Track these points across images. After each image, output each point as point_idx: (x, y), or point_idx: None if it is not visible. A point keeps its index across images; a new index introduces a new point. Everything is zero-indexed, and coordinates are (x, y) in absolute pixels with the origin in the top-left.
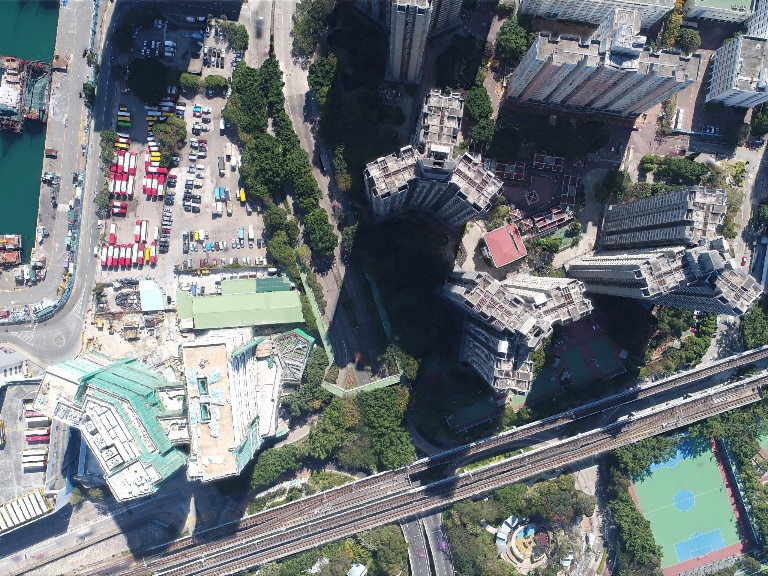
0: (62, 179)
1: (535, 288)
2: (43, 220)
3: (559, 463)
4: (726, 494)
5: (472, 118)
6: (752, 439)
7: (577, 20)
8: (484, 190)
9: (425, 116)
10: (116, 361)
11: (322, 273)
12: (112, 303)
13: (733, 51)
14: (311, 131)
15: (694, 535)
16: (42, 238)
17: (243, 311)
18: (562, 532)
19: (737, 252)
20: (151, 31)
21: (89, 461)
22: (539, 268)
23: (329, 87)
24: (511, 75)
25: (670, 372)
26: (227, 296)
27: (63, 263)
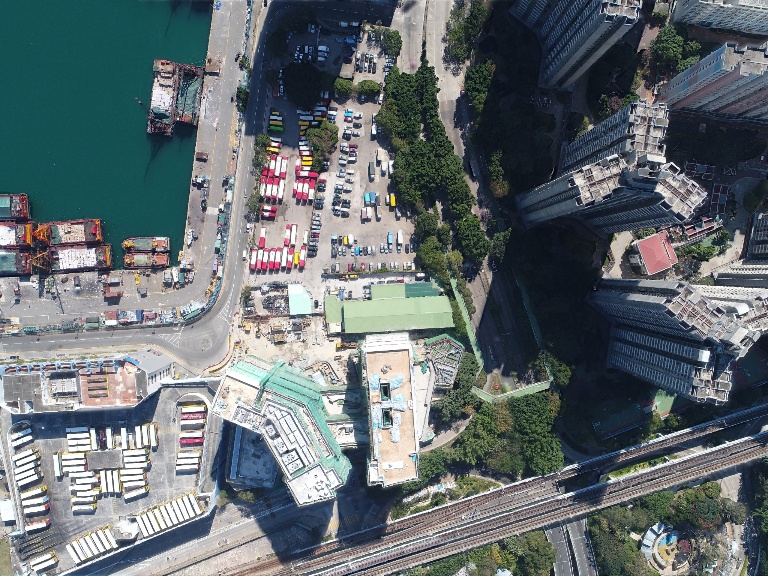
0: (212, 182)
1: (720, 297)
2: (192, 223)
3: (708, 471)
4: None
5: None
6: None
7: (731, 29)
8: (688, 200)
9: (630, 125)
10: (273, 365)
11: (469, 279)
12: (259, 306)
13: None
14: (461, 137)
15: None
16: (191, 241)
17: (394, 316)
18: None
19: None
20: (304, 36)
21: (241, 464)
22: (688, 276)
23: (486, 93)
24: (664, 83)
25: None
26: (378, 301)
27: (212, 266)
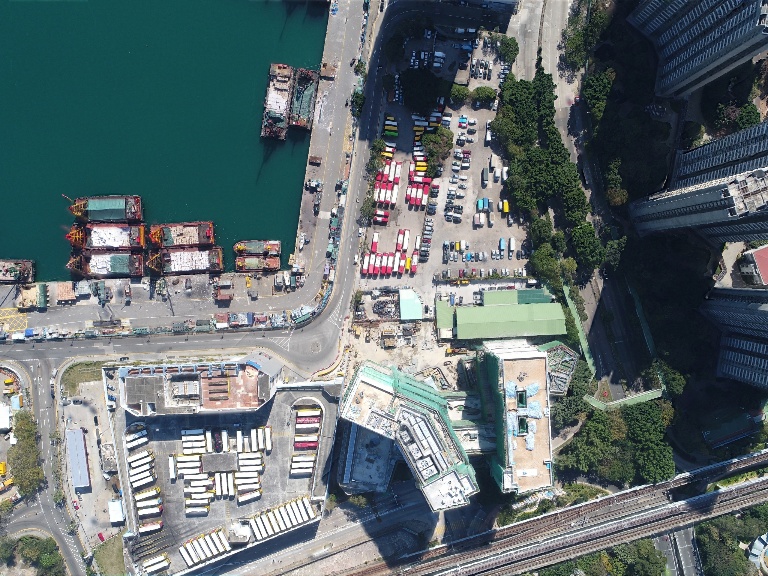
0: (324, 186)
1: None
2: (304, 227)
3: None
4: None
5: None
6: None
7: None
8: None
9: None
10: (391, 370)
11: (580, 286)
12: (369, 311)
13: None
14: (574, 144)
15: None
16: (303, 245)
17: (507, 322)
18: None
19: None
20: (420, 41)
21: (355, 468)
22: None
23: (604, 101)
24: None
25: None
26: (491, 307)
27: None
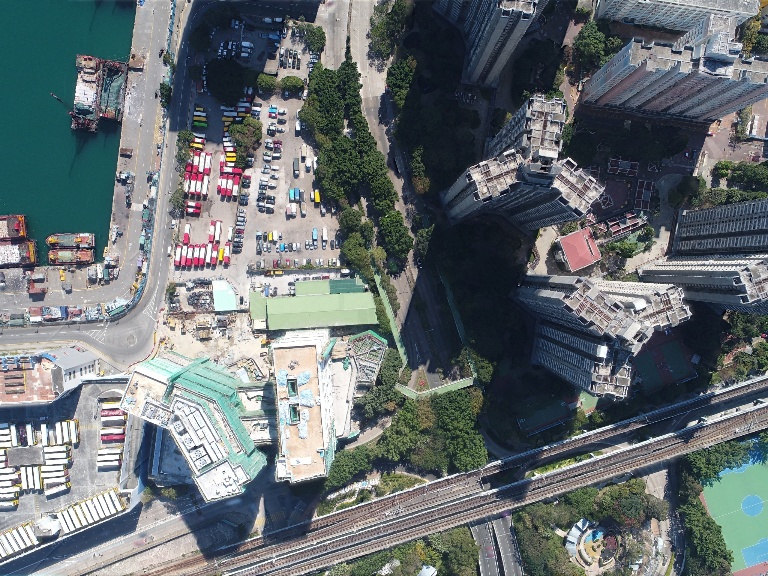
0: (136, 178)
1: (626, 293)
2: (117, 219)
3: (631, 467)
4: None
5: None
6: None
7: (654, 25)
8: (585, 195)
9: (527, 121)
10: (193, 361)
11: (395, 275)
12: (184, 303)
13: None
14: (386, 133)
15: (762, 540)
16: (116, 237)
17: (317, 312)
18: (630, 536)
19: None
20: (228, 31)
21: (163, 460)
22: (612, 272)
23: (407, 90)
24: (588, 79)
25: (743, 378)
26: (301, 297)
27: (136, 262)
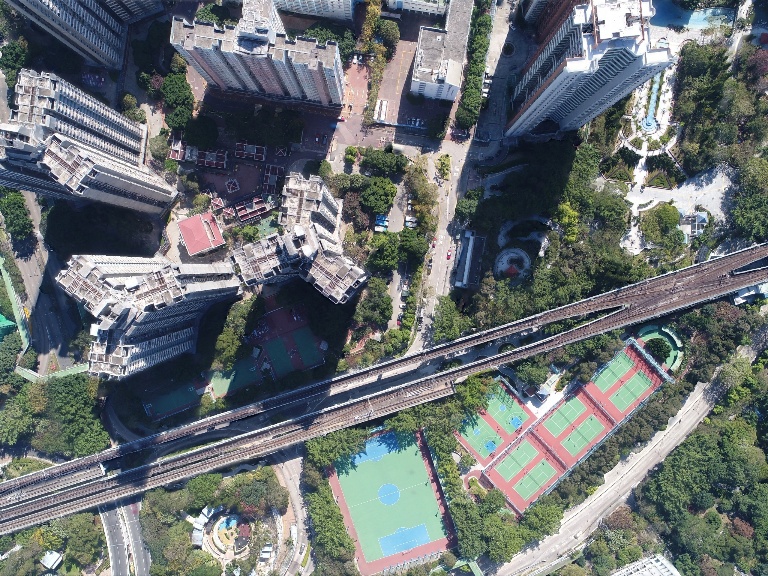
0: None
1: None
2: None
3: (251, 454)
4: (431, 489)
5: (169, 105)
6: (449, 434)
7: (279, 9)
8: (76, 172)
9: (18, 96)
10: None
11: (25, 258)
12: None
13: None
14: None
15: (399, 530)
16: None
17: None
18: None
19: (442, 246)
20: None
21: None
22: None
23: None
24: None
25: (366, 364)
26: None
27: None
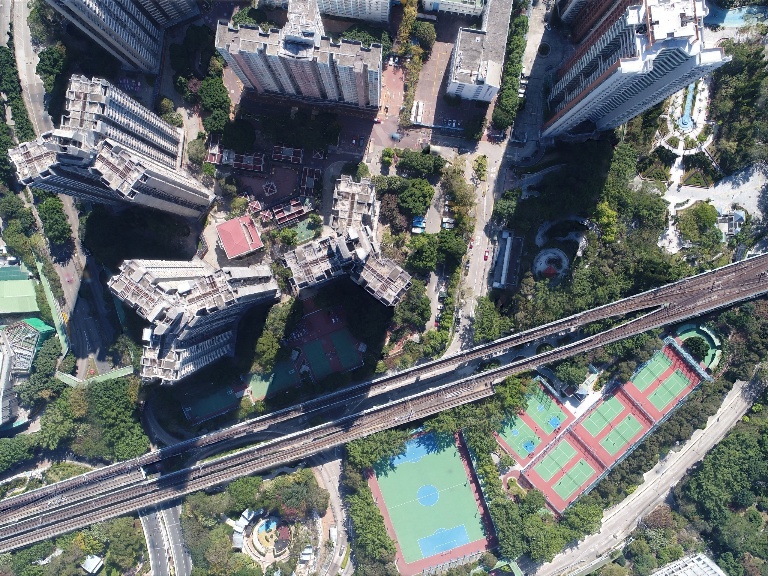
0: None
1: None
2: None
3: (292, 456)
4: (470, 490)
5: (206, 108)
6: (488, 434)
7: None
8: (127, 177)
9: (69, 101)
10: None
11: (63, 263)
12: None
13: (456, 44)
14: None
15: (438, 531)
16: None
17: None
18: (305, 526)
19: (480, 246)
20: None
21: None
22: (277, 260)
23: None
24: None
25: (405, 366)
26: None
27: None
